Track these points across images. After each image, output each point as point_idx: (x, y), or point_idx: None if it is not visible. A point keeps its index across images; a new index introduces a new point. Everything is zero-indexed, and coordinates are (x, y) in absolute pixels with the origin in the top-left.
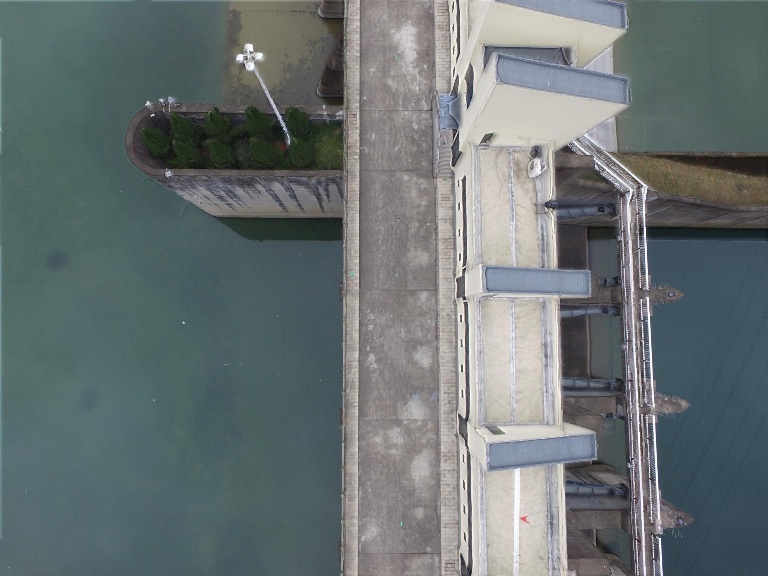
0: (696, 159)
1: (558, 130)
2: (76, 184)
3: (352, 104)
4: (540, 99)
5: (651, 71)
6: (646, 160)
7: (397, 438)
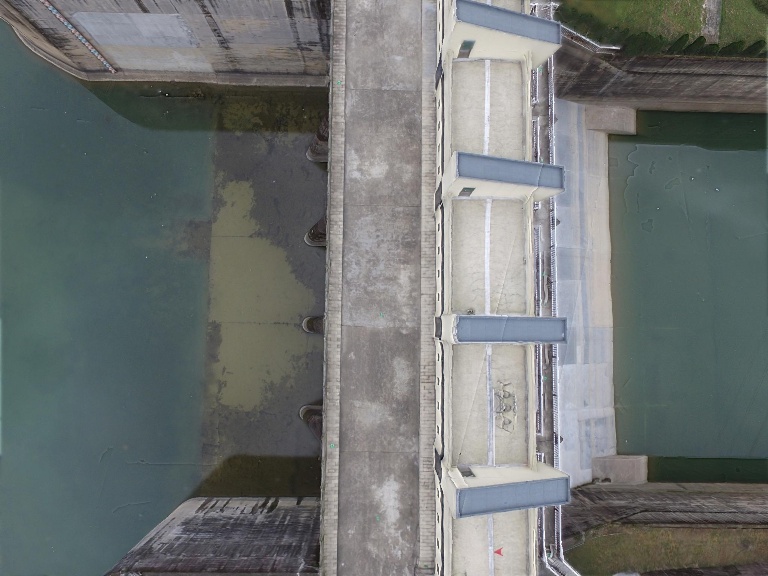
0: None
1: None
2: (44, 513)
3: (328, 575)
4: None
5: (653, 353)
6: (646, 531)
7: None
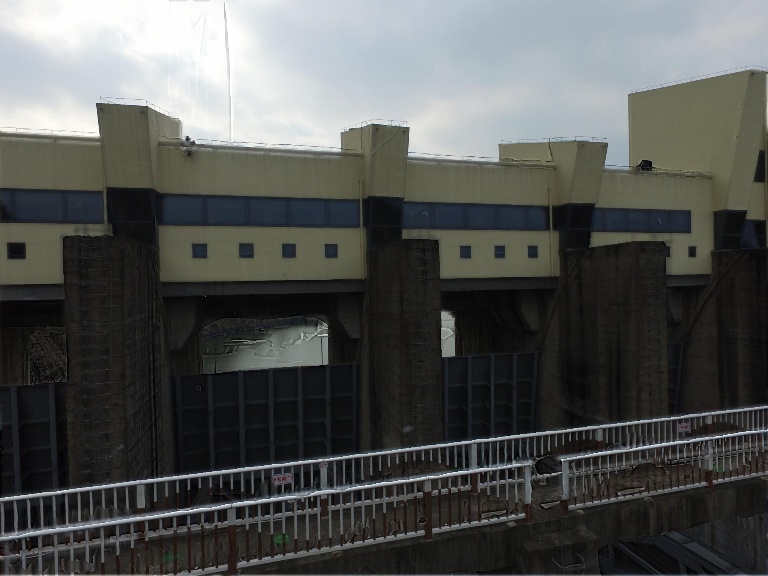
0: None
1: (704, 147)
2: None
3: None
4: (663, 100)
5: None
6: None
7: None
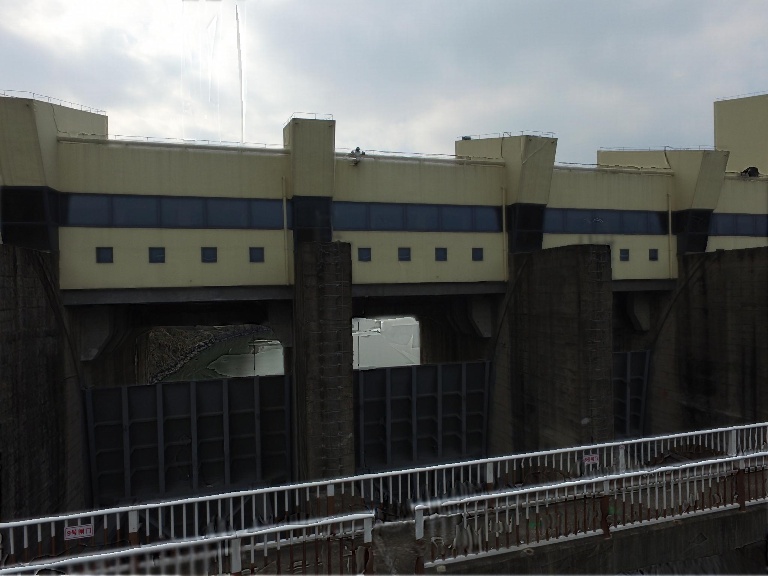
0: None
1: None
2: None
3: None
4: (756, 108)
5: None
6: None
7: None
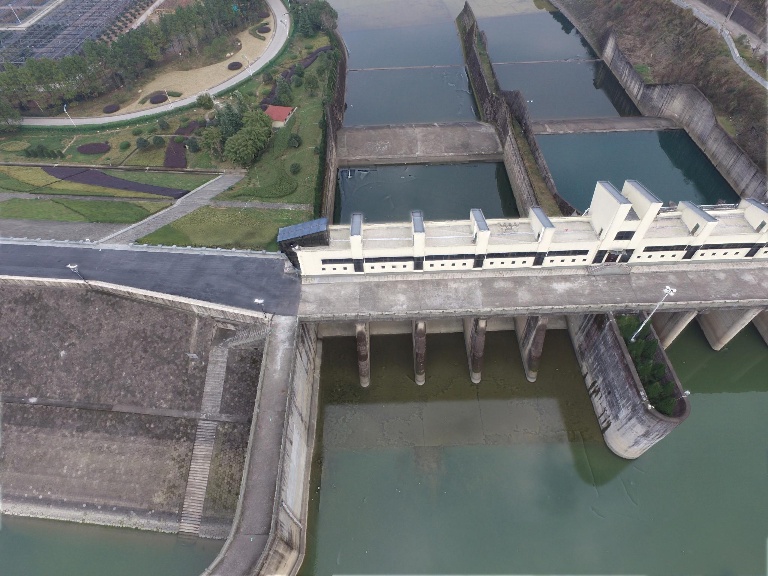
0: (540, 204)
1: None
2: (659, 566)
3: None
4: None
5: None
6: None
7: (767, 284)
